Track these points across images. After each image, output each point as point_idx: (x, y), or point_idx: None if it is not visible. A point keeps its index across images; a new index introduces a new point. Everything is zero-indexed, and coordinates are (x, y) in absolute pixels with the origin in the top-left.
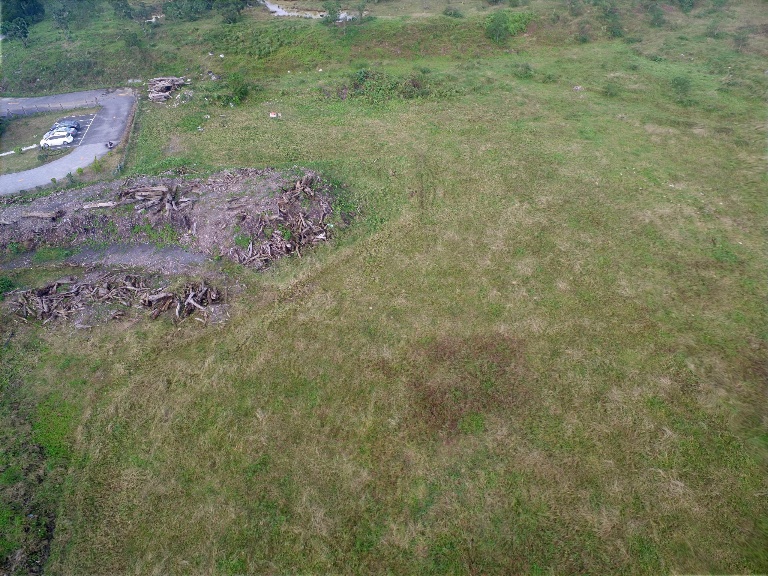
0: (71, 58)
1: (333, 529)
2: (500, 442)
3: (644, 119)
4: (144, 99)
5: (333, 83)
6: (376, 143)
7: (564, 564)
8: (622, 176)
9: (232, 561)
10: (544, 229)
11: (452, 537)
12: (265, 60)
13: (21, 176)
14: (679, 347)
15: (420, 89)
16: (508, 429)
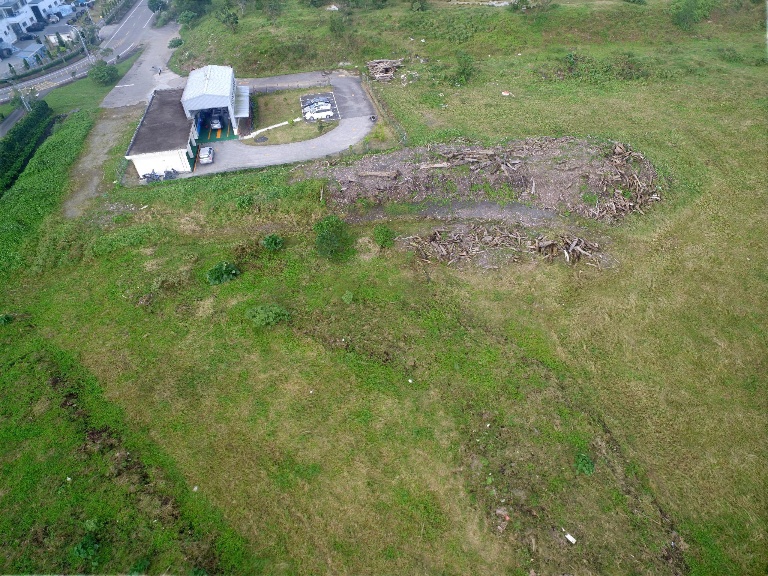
0: (283, 42)
1: None
2: None
3: None
4: None
5: (547, 65)
6: (634, 118)
7: None
8: None
9: None
10: None
11: None
12: (465, 45)
13: (310, 144)
14: None
15: None
16: None
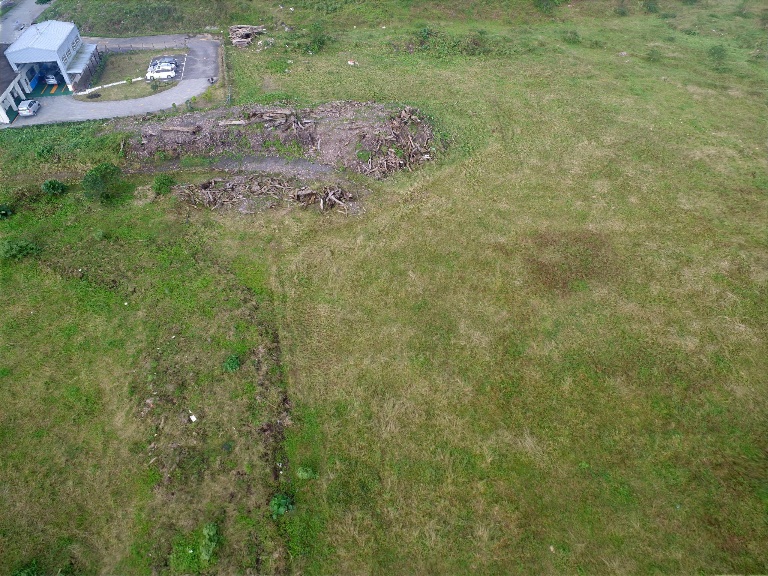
0: (151, 3)
1: (490, 343)
2: (603, 297)
3: (685, 81)
4: (227, 44)
5: (401, 38)
6: (453, 89)
7: (663, 367)
8: (671, 125)
9: (420, 359)
10: (612, 160)
11: (579, 350)
12: (332, 15)
13: (140, 102)
14: (732, 244)
15: (480, 48)
16: (608, 290)
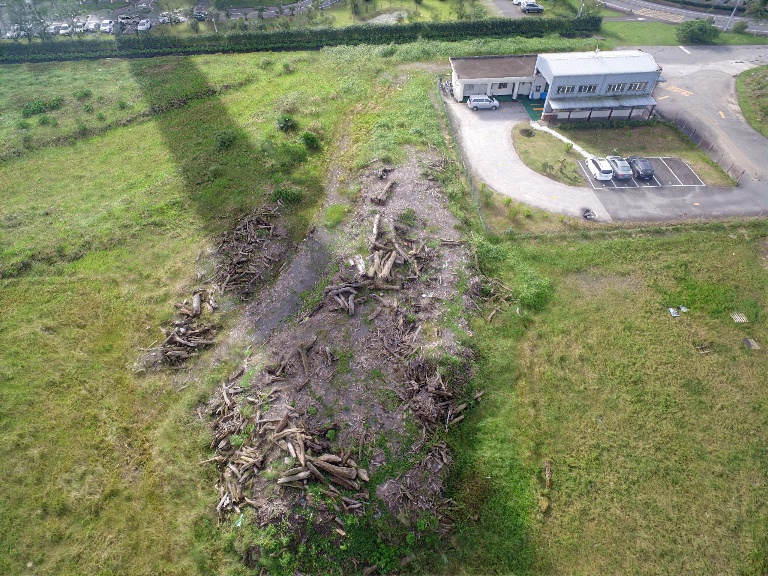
0: None
1: None
2: None
3: None
4: None
5: None
6: None
7: None
8: None
9: None
10: None
11: None
12: None
13: (510, 163)
14: None
15: None
16: None
